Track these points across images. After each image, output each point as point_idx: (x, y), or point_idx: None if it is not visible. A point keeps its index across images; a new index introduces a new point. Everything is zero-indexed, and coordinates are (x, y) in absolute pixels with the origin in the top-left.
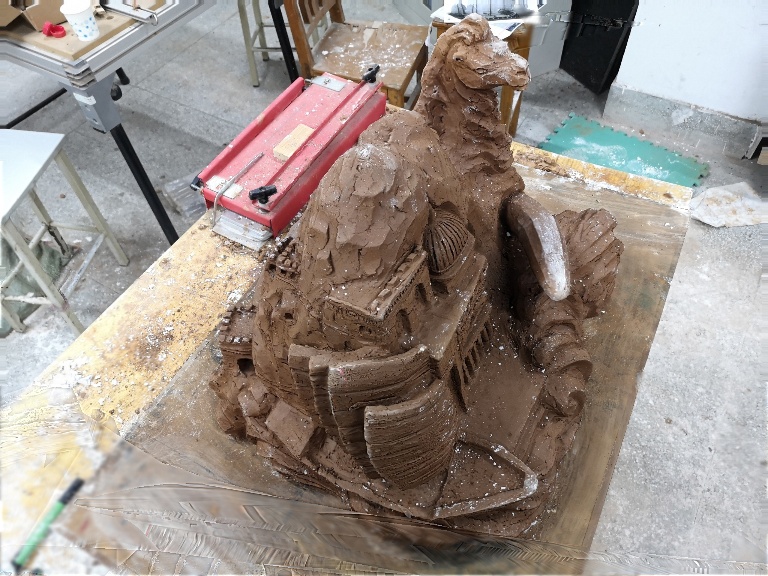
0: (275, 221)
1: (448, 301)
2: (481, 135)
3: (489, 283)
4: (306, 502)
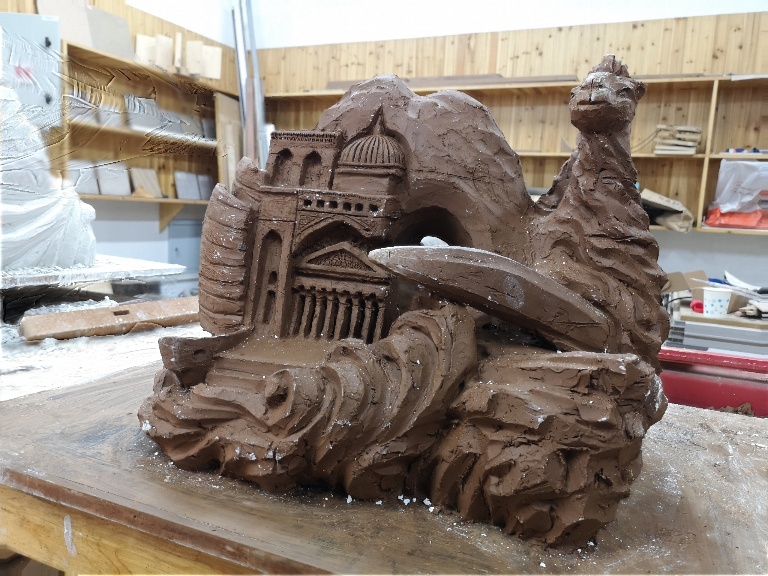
0: None
1: None
2: (577, 195)
3: None
4: None
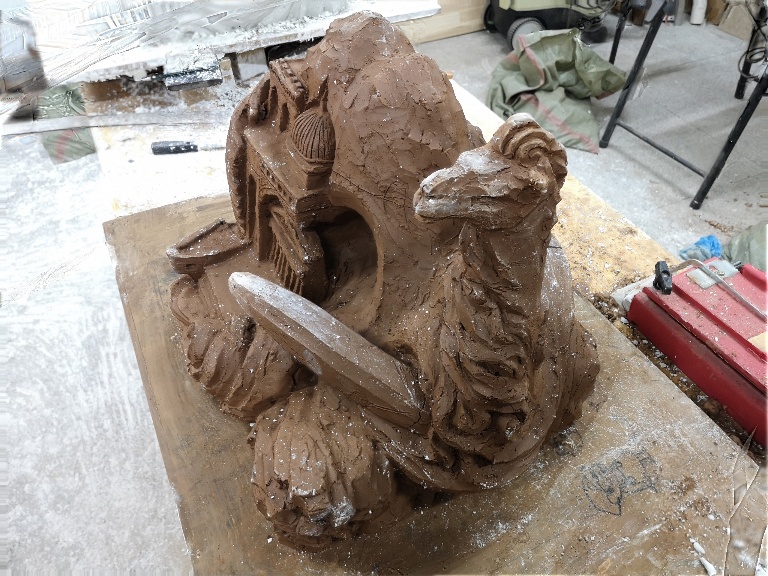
0: (637, 305)
1: (281, 155)
2: None
3: (341, 321)
4: None
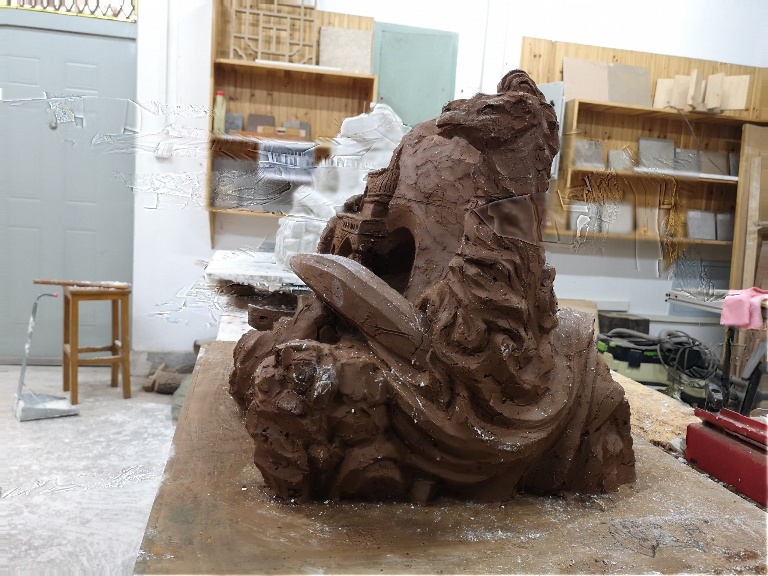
0: (692, 435)
1: None
2: None
3: None
4: (329, 156)
